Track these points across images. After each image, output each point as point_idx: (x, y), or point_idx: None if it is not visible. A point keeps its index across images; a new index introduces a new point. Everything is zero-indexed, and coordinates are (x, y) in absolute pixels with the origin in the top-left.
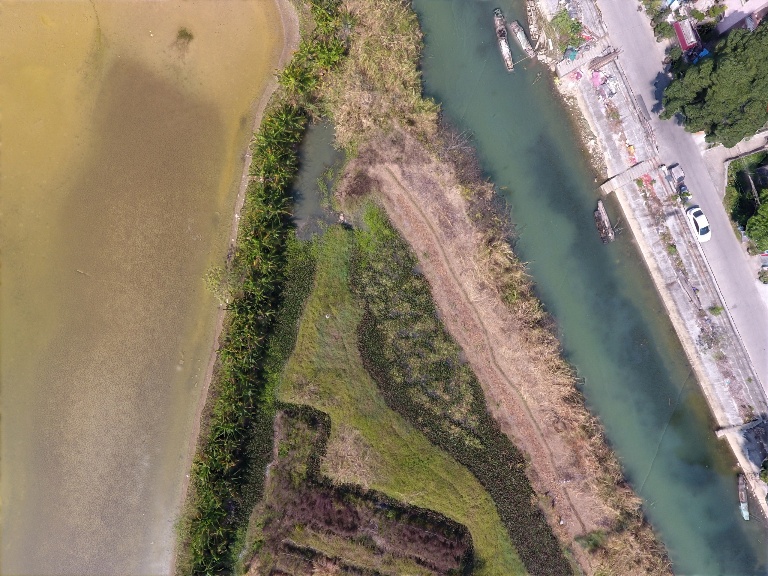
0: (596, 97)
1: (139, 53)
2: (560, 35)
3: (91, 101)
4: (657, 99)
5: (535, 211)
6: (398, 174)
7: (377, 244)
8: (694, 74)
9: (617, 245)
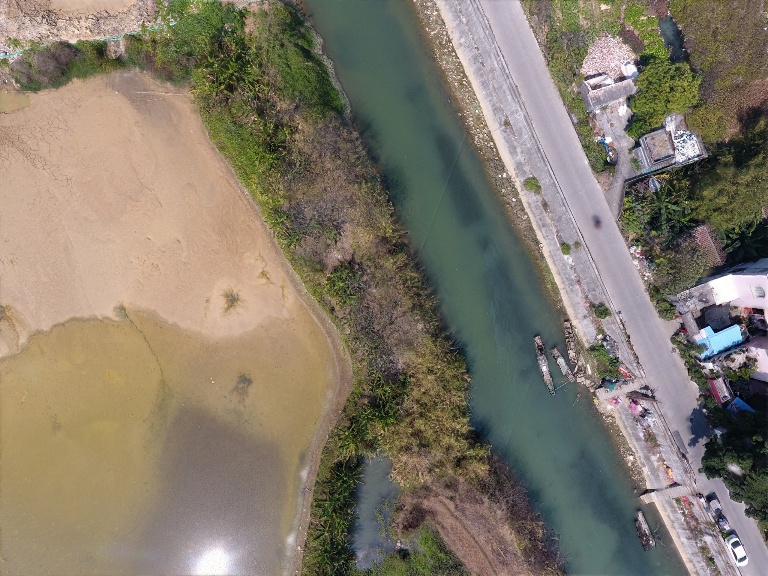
0: (634, 423)
1: (201, 400)
2: (598, 363)
3: (158, 448)
4: (693, 434)
5: (579, 523)
6: (451, 506)
7: (433, 566)
8: (734, 461)
9: (657, 549)
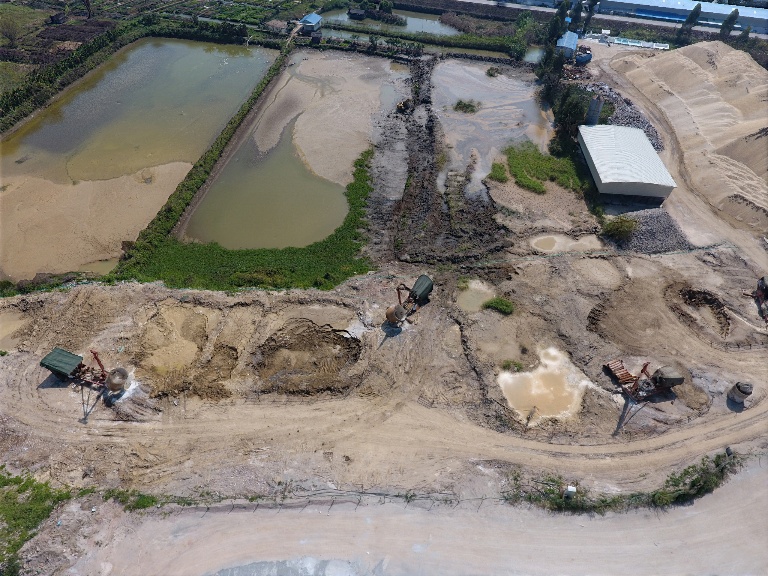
0: None
1: None
2: None
3: None
4: None
5: None
6: None
7: None
8: None
9: None
